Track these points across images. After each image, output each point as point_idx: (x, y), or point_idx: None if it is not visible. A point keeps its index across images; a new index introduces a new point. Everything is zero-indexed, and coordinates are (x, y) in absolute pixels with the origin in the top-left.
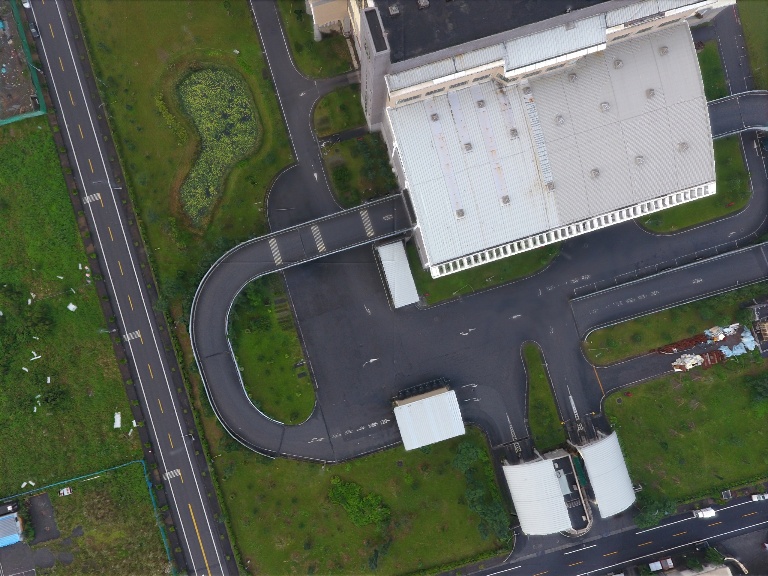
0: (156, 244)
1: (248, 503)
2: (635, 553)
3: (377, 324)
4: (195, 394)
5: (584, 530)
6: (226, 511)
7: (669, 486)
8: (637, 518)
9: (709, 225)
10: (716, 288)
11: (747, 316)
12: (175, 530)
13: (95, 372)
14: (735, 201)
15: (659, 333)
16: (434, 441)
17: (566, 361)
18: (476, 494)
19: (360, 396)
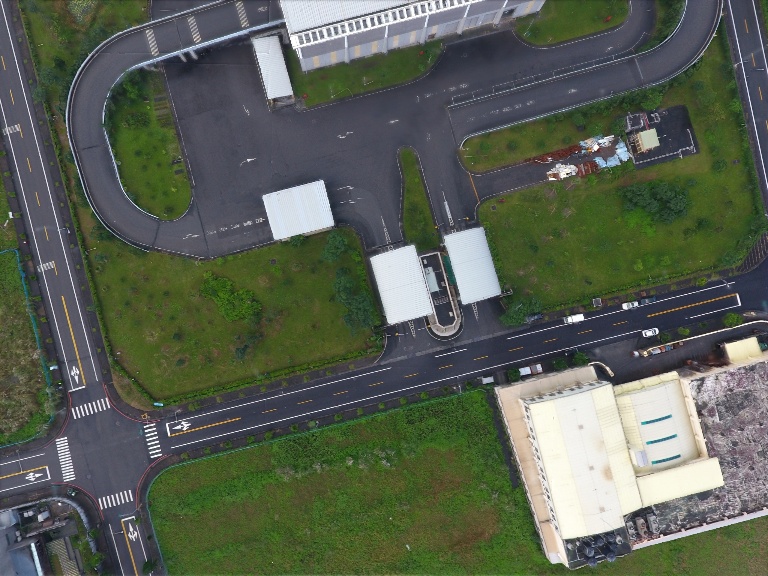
0: (39, 40)
1: (121, 296)
2: (505, 358)
3: (255, 124)
4: (72, 188)
5: (452, 328)
6: (98, 302)
7: (541, 293)
8: (503, 315)
9: (587, 39)
10: (591, 98)
11: (619, 123)
12: (47, 321)
13: None
14: (612, 14)
15: (535, 143)
16: (303, 231)
17: (442, 167)
18: (341, 281)
19: (236, 195)
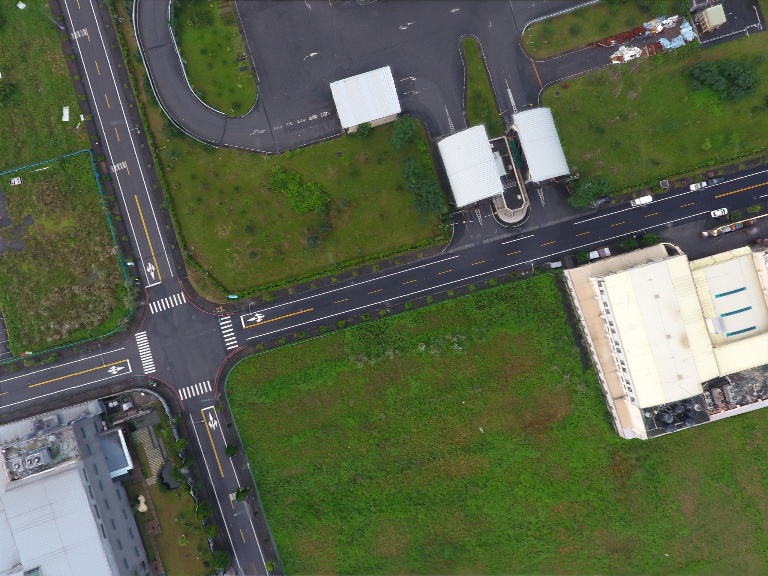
0: None
1: (192, 193)
2: (573, 243)
3: (317, 19)
4: (140, 88)
5: (520, 211)
6: (170, 199)
7: (607, 177)
8: (572, 197)
9: None
10: None
11: (684, 0)
12: (122, 220)
13: (44, 66)
14: None
15: (597, 26)
16: (370, 119)
17: (504, 55)
18: (410, 165)
19: (301, 89)
